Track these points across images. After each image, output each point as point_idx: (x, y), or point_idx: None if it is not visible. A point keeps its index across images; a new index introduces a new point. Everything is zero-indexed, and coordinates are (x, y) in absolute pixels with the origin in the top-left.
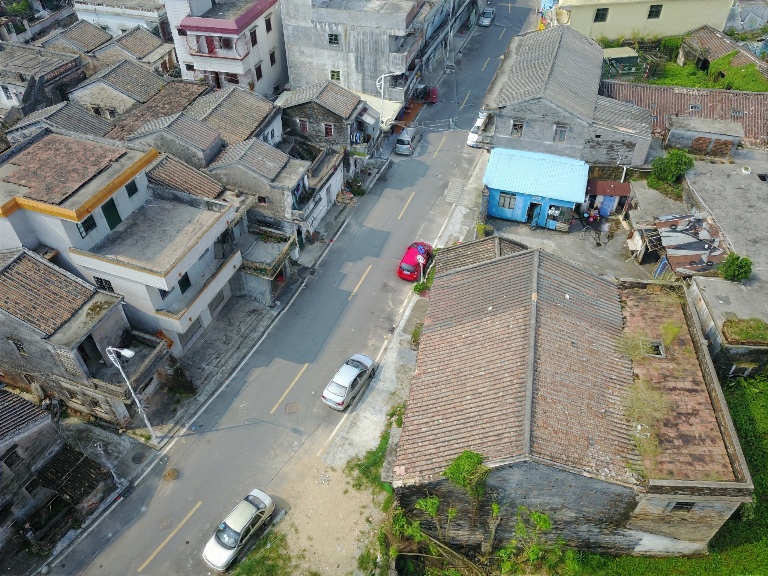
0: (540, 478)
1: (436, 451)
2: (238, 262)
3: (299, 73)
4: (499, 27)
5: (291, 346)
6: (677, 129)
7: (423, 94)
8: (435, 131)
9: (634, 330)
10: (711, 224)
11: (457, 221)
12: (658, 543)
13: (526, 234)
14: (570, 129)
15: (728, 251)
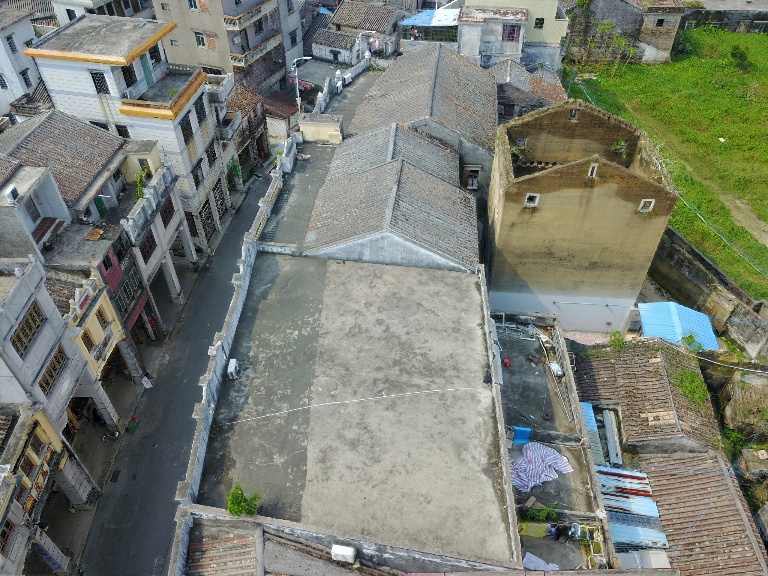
0: (609, 4)
1: (570, 3)
2: None
3: None
4: None
5: None
6: None
7: None
8: None
9: None
10: None
11: None
12: (651, 53)
13: None
14: None
15: None
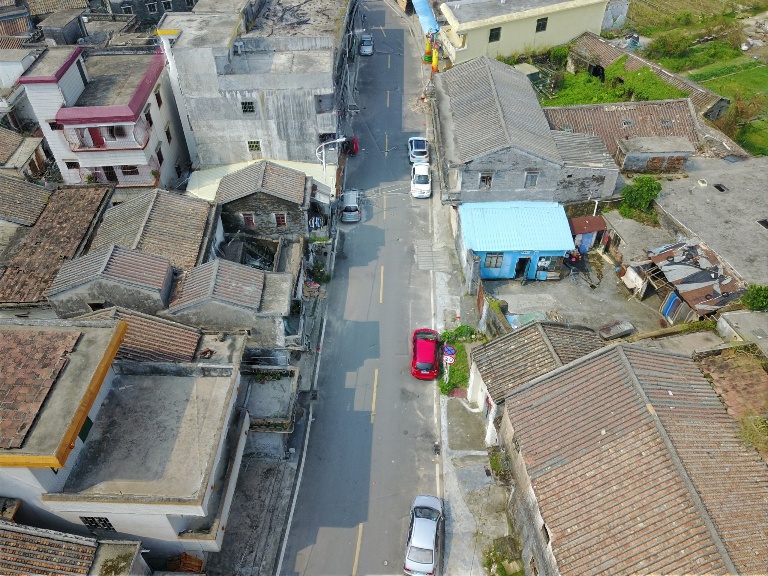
0: None
1: None
2: (247, 425)
3: (209, 149)
4: (382, 54)
5: (332, 505)
6: (633, 153)
7: (350, 149)
8: (372, 186)
9: (738, 410)
10: (706, 250)
11: (444, 291)
12: None
13: (520, 291)
14: (542, 173)
15: (736, 277)
